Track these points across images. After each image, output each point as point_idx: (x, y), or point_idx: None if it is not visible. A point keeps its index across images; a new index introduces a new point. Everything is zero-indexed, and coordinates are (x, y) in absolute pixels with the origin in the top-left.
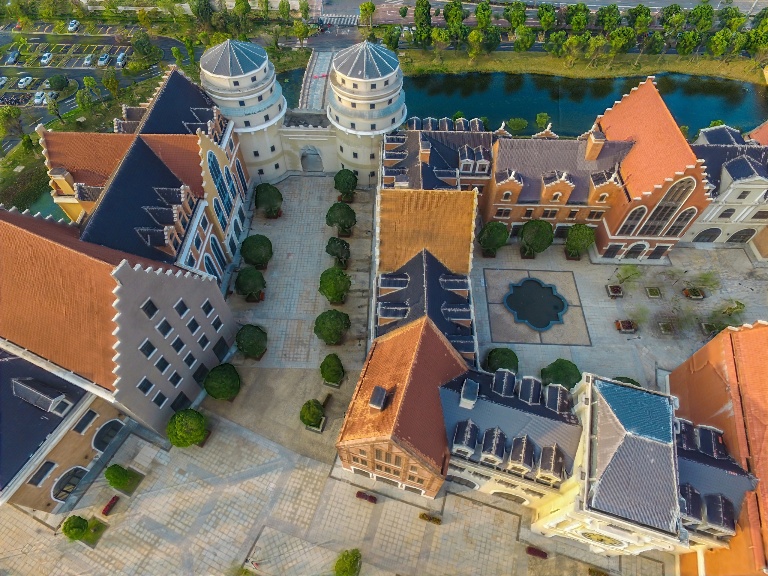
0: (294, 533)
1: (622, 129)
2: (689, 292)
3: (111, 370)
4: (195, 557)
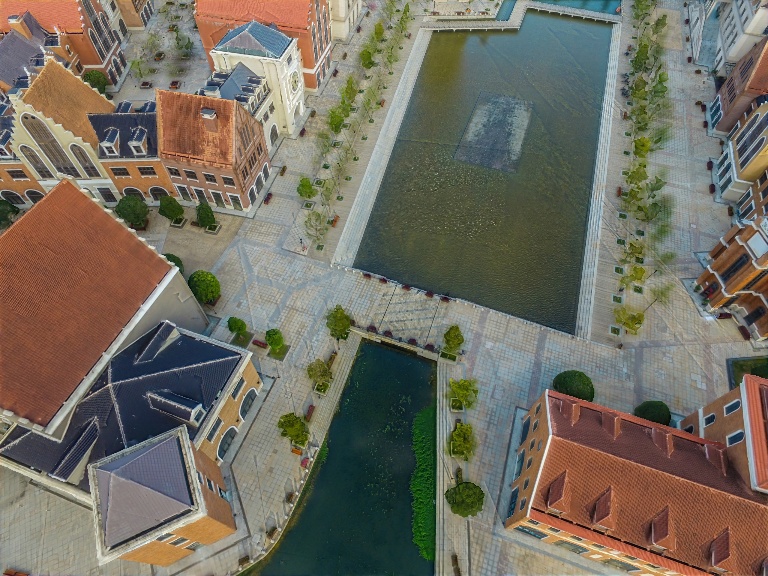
0: (287, 233)
1: (7, 16)
2: (158, 57)
3: (150, 258)
4: (299, 282)
